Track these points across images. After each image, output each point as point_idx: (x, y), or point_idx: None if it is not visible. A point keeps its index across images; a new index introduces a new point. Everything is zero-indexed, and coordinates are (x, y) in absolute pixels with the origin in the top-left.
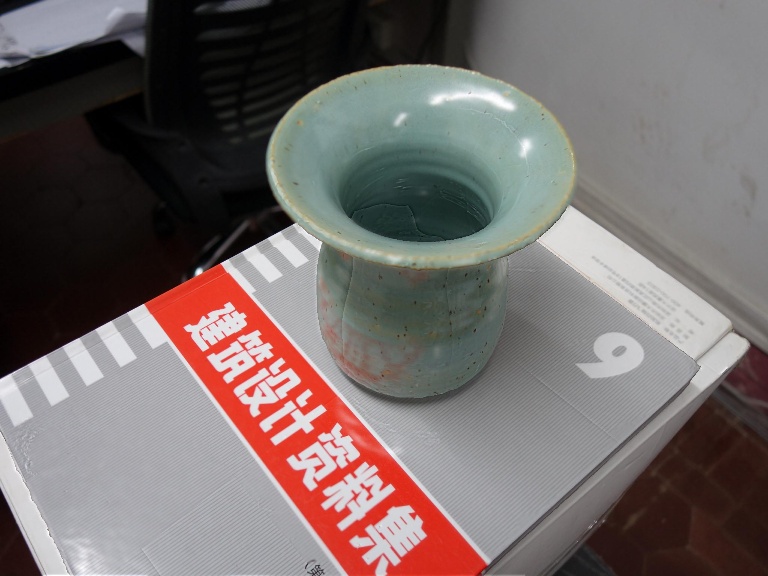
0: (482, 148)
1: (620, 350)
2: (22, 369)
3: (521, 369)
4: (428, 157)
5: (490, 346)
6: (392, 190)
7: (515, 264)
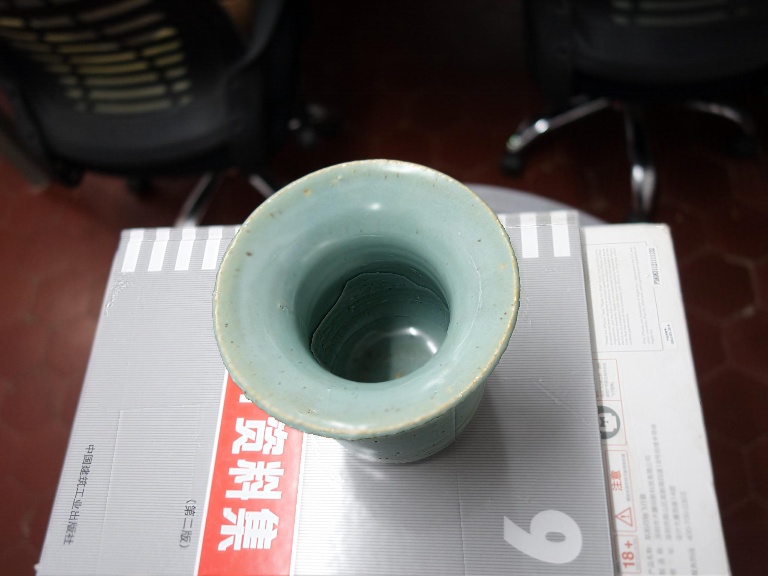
0: (458, 300)
1: (557, 537)
2: (152, 231)
3: (455, 483)
4: (432, 269)
5: (409, 455)
6: (410, 271)
7: (549, 385)
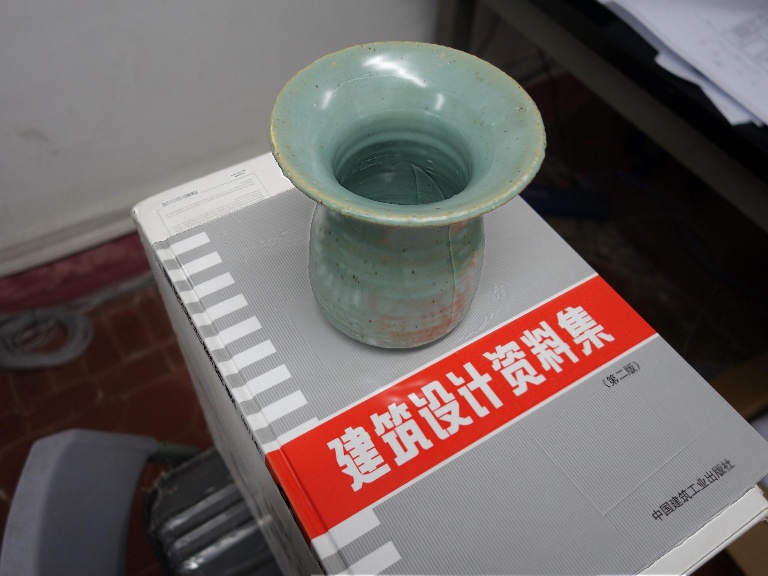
0: (363, 108)
1: None
2: None
3: None
4: (338, 156)
5: None
6: None
7: None
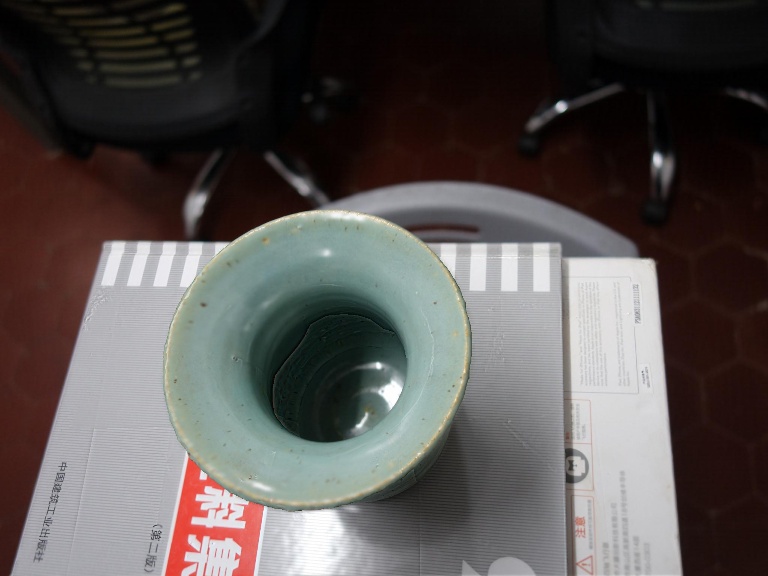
0: (412, 361)
1: None
2: (133, 243)
3: (417, 524)
4: None
5: (368, 498)
6: (375, 316)
7: (517, 426)
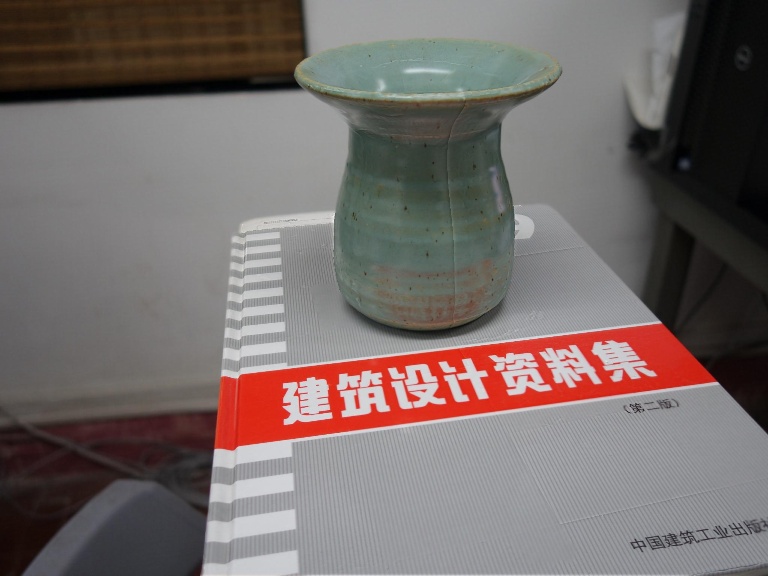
0: (410, 84)
1: None
2: None
3: None
4: None
5: None
6: None
7: None
